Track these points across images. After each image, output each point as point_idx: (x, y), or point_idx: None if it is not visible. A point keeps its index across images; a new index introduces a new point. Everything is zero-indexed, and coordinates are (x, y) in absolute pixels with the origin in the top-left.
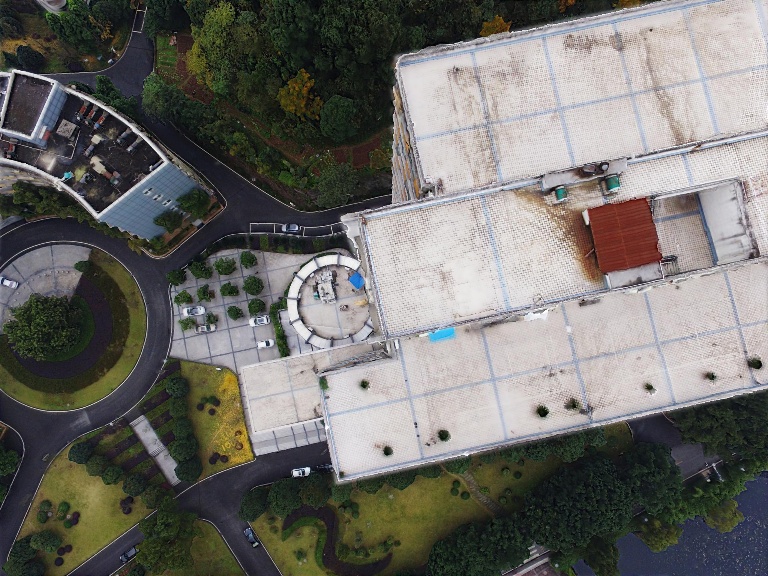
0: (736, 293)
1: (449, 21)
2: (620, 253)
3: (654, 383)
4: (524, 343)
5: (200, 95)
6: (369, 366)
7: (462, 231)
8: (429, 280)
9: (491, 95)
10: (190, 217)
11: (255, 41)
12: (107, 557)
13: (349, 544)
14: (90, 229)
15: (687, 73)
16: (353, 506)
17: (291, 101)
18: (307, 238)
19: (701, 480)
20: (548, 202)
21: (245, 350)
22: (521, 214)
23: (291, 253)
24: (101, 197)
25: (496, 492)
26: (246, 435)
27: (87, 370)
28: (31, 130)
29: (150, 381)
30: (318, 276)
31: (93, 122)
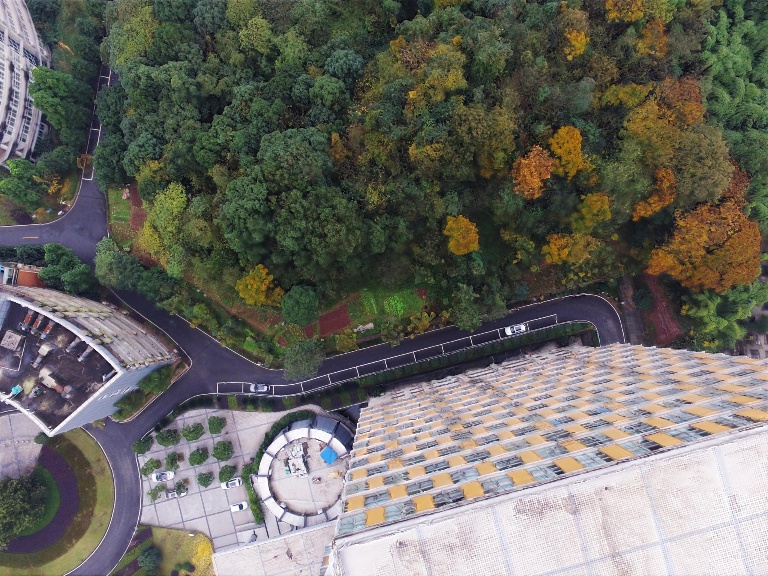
0: None
1: (412, 210)
2: None
3: None
4: None
5: None
6: None
7: None
8: None
9: (437, 571)
10: None
11: (208, 235)
12: None
13: None
14: None
15: (645, 535)
16: None
17: (250, 296)
18: (277, 398)
19: None
20: None
21: (218, 513)
22: None
23: (261, 411)
24: (53, 410)
25: None
26: None
27: (55, 543)
28: None
29: (121, 549)
30: (288, 452)
31: (39, 333)
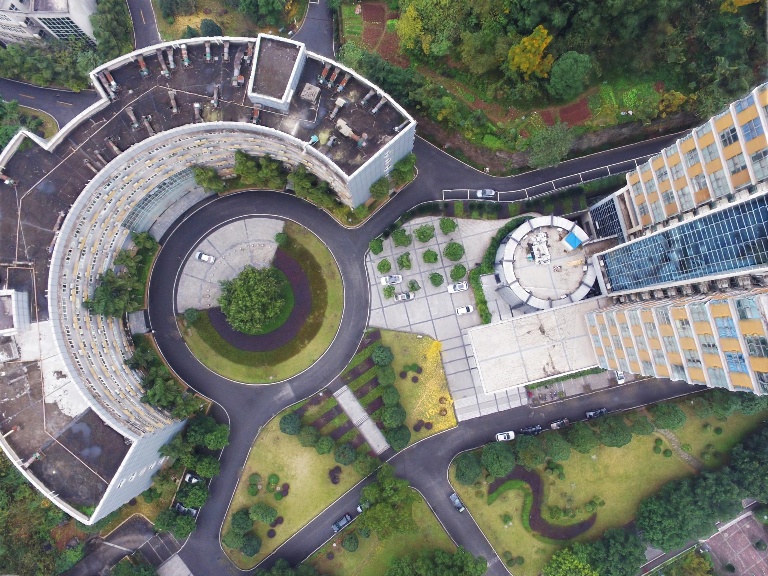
0: None
1: None
2: None
3: None
4: None
5: (393, 62)
6: None
7: None
8: None
9: None
10: None
11: None
12: (318, 527)
13: None
14: (282, 202)
15: None
16: (559, 467)
17: (526, 59)
18: (503, 203)
19: None
20: None
21: (444, 317)
22: None
23: (485, 219)
24: (347, 160)
25: (697, 449)
26: None
27: (289, 342)
28: (280, 94)
29: (351, 351)
30: (533, 237)
31: (337, 85)
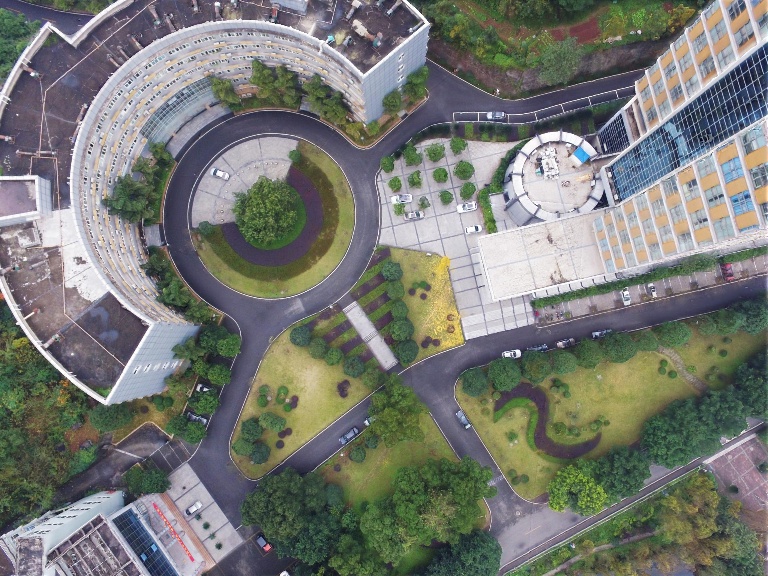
0: None
1: None
2: None
3: None
4: None
5: None
6: None
7: None
8: None
9: None
10: None
11: None
12: (326, 440)
13: None
14: (295, 122)
15: None
16: (564, 386)
17: None
18: (513, 124)
19: None
20: None
21: (453, 236)
22: None
23: (495, 141)
24: (362, 60)
25: (702, 371)
26: None
27: (300, 258)
28: None
29: (361, 268)
30: (542, 152)
31: None
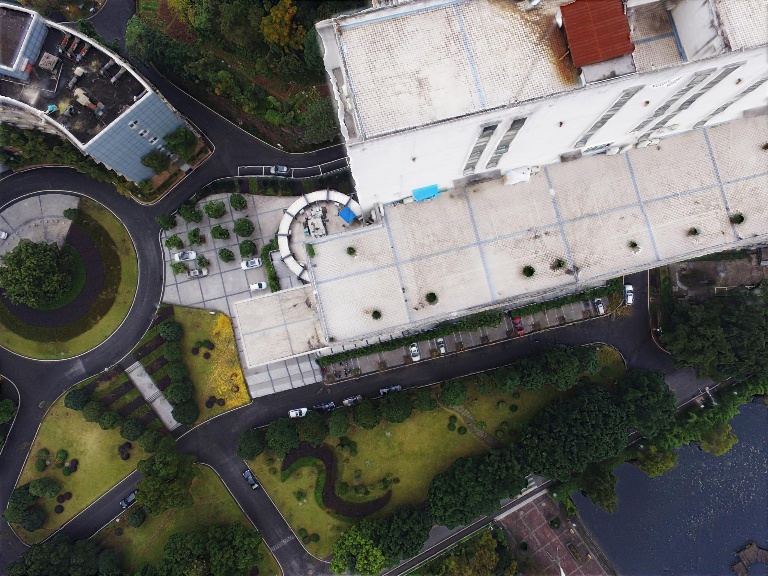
0: (716, 152)
1: None
2: (593, 47)
3: (638, 242)
4: (508, 207)
5: (184, 38)
6: (355, 234)
7: (437, 39)
8: (405, 87)
9: None
10: (178, 161)
11: None
12: (107, 503)
13: (348, 483)
14: (78, 178)
15: None
16: (351, 444)
17: (274, 29)
18: (296, 179)
19: (695, 406)
20: (521, 8)
21: (238, 293)
22: (495, 21)
23: (281, 195)
24: (86, 129)
25: (493, 426)
26: (242, 377)
27: (80, 318)
28: (13, 62)
29: (144, 327)
30: (308, 212)
31: (75, 54)
